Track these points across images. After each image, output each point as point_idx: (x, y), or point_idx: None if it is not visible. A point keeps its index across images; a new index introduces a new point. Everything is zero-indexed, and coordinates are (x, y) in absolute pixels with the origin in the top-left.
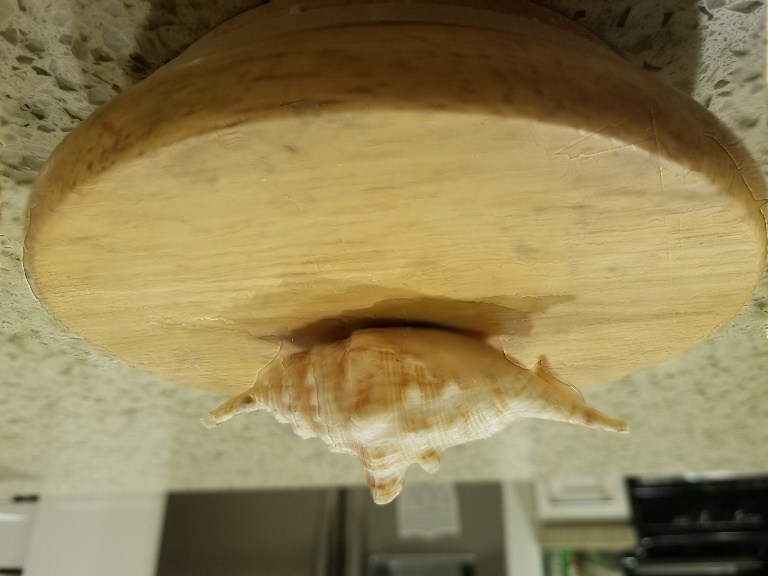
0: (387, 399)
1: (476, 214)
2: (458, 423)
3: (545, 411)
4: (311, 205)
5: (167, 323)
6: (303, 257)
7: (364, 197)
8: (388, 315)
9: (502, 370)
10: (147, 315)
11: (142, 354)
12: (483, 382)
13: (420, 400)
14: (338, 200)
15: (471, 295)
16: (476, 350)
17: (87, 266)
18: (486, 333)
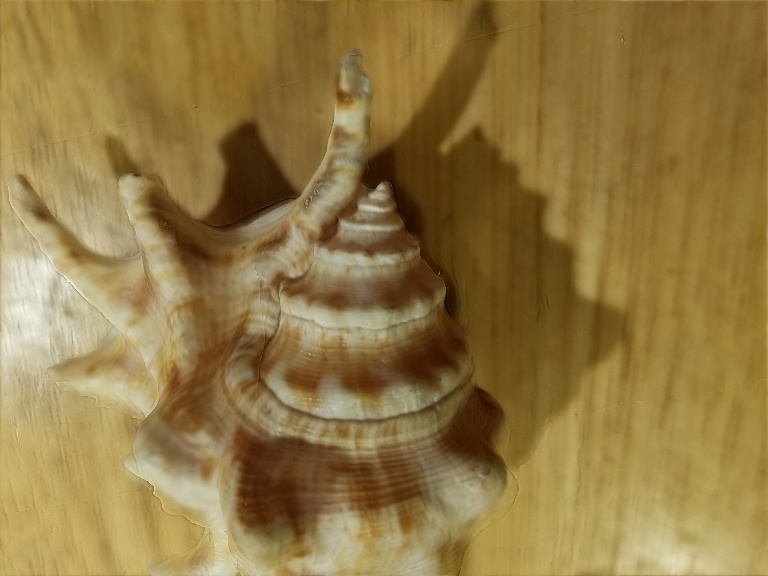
0: None
1: (676, 541)
2: None
3: None
4: (764, 395)
5: (463, 23)
6: (643, 345)
7: (756, 449)
8: None
9: None
10: (512, 8)
11: None
12: None
13: None
14: (762, 424)
15: None
16: None
17: (725, 30)
18: None
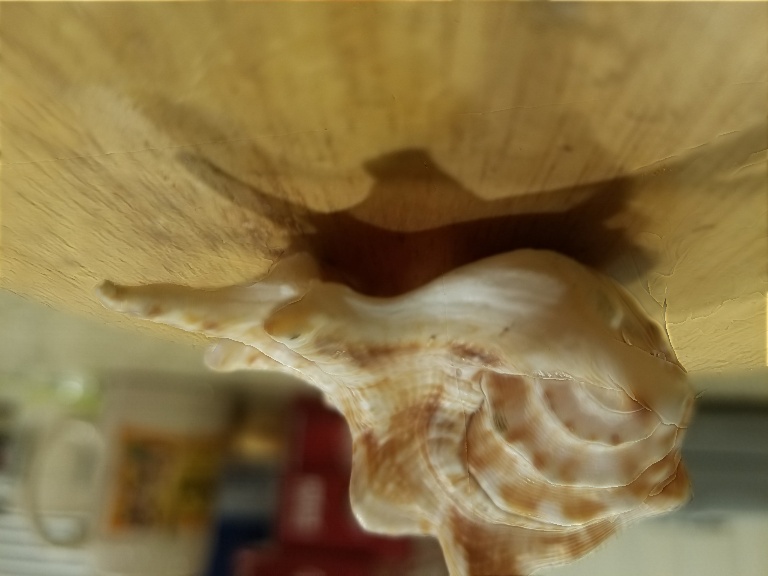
0: None
1: None
2: None
3: None
4: None
5: None
6: None
7: None
8: None
9: None
10: None
11: None
12: None
13: None
14: None
15: None
16: None
17: None
18: None
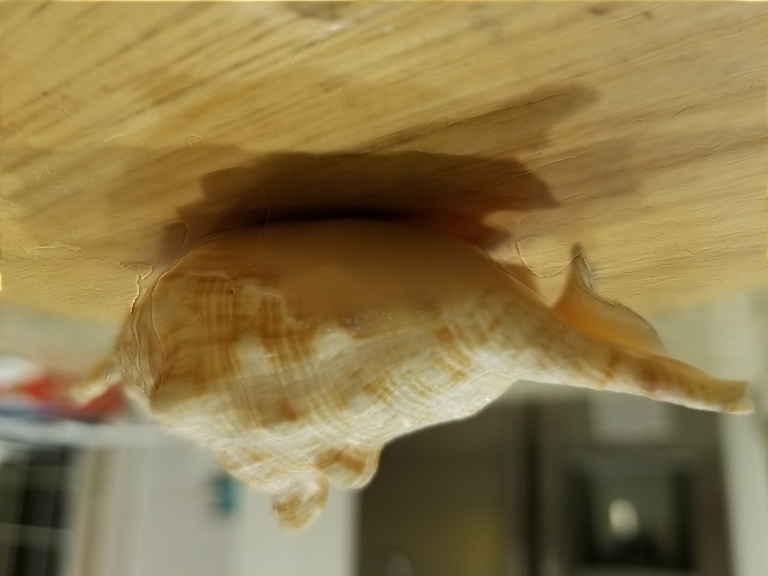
0: (204, 369)
1: None
2: (360, 405)
3: (546, 371)
4: None
5: (14, 259)
6: None
7: None
8: (237, 206)
9: (453, 289)
10: None
11: (68, 298)
12: (410, 318)
13: (271, 366)
14: None
15: (344, 139)
16: (407, 252)
17: None
18: (442, 214)
